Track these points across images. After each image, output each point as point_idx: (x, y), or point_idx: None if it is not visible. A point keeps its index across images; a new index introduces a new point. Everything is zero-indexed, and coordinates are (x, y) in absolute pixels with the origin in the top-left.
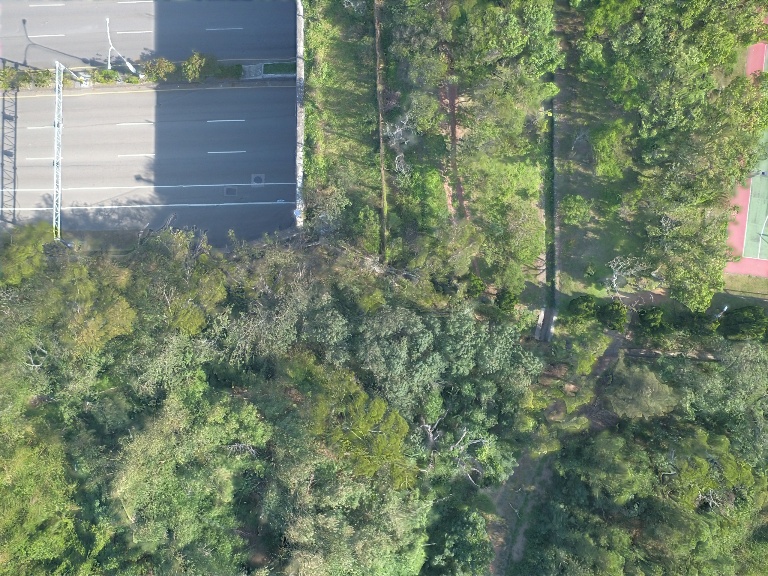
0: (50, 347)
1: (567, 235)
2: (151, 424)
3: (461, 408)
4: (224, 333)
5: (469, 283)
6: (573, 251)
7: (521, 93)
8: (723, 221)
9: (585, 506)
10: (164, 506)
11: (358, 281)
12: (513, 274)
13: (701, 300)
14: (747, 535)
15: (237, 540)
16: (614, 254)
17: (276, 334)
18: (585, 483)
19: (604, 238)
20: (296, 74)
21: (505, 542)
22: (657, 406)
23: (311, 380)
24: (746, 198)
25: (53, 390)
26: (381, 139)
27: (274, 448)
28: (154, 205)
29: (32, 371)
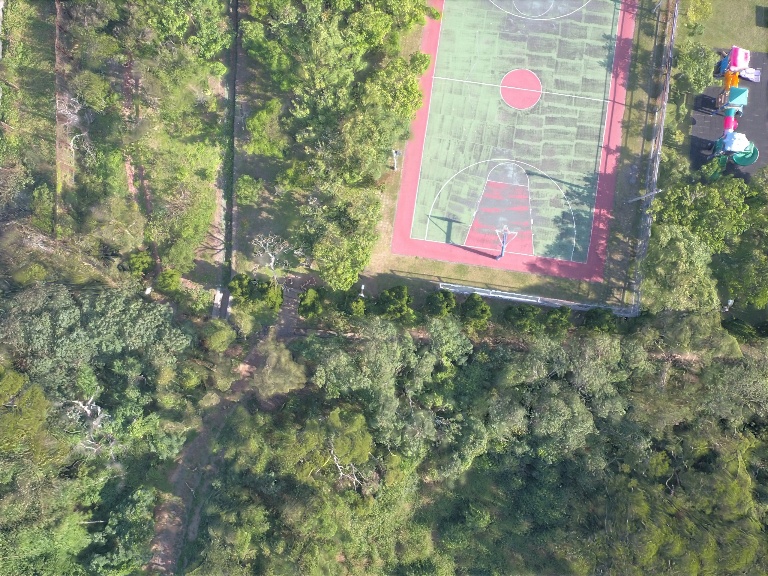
0: None
1: (243, 215)
2: None
3: (125, 385)
4: None
5: (129, 260)
6: (248, 231)
7: (174, 71)
8: (370, 200)
9: None
10: None
11: (49, 260)
12: (179, 252)
13: (339, 278)
14: (408, 516)
15: None
16: (287, 234)
17: None
18: None
19: (278, 218)
20: None
21: (181, 521)
22: (281, 383)
23: None
24: (415, 179)
25: None
26: (56, 117)
27: None
28: None
29: None
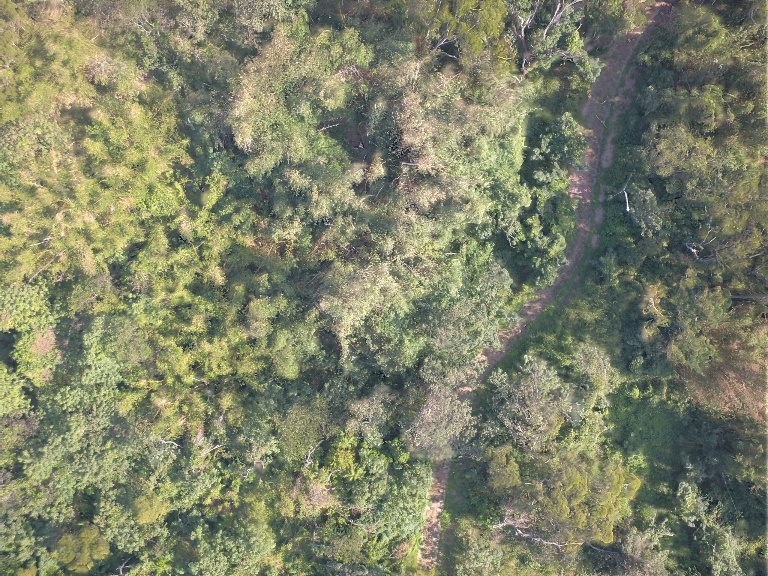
0: (157, 17)
1: None
2: (258, 68)
3: None
4: None
5: None
6: None
7: None
8: None
9: None
10: (277, 133)
11: None
12: None
13: None
14: None
15: (346, 162)
16: None
17: None
18: (669, 67)
19: None
20: None
21: (594, 152)
22: None
23: (407, 3)
24: None
25: (160, 64)
26: None
27: (376, 68)
28: None
29: (143, 36)
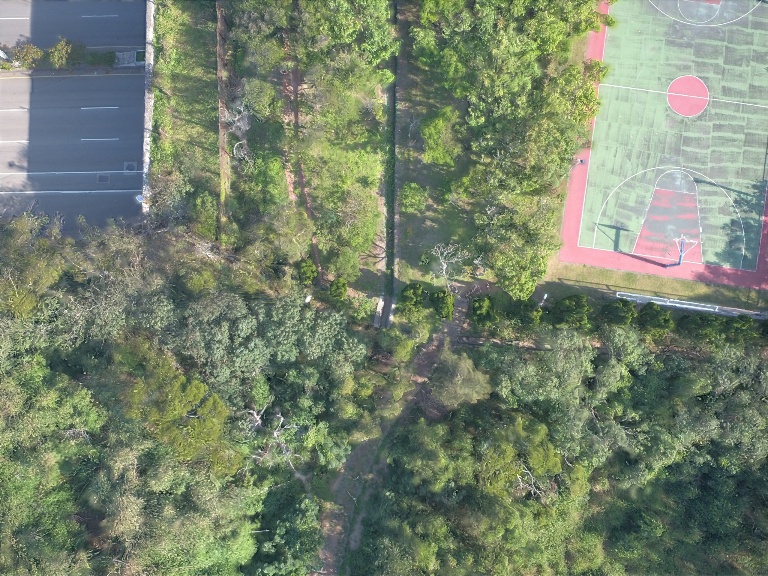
0: None
1: (406, 223)
2: None
3: (293, 395)
4: (54, 317)
5: (299, 269)
6: (411, 239)
7: (349, 79)
8: (548, 209)
9: (411, 494)
10: (0, 490)
11: (204, 268)
12: (346, 261)
13: (521, 288)
14: (578, 524)
15: (73, 525)
16: None
17: (105, 319)
18: (412, 471)
19: (442, 226)
20: (145, 60)
21: (343, 530)
22: (470, 393)
23: (145, 365)
24: (582, 187)
25: None
26: (219, 125)
27: (108, 433)
28: (27, 192)
29: None
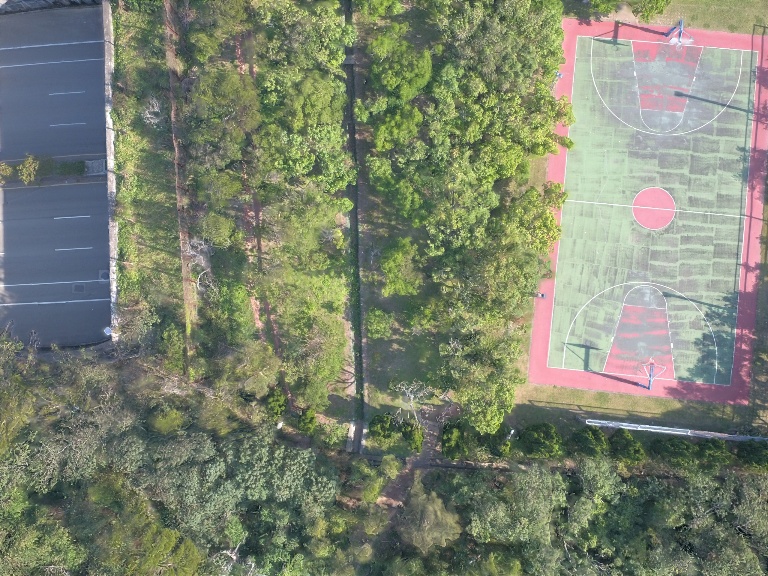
0: None
1: (373, 347)
2: None
3: (267, 528)
4: (26, 462)
5: (267, 405)
6: (379, 364)
7: (306, 216)
8: (512, 340)
9: None
10: None
11: (176, 394)
12: (314, 392)
13: (487, 424)
14: None
15: None
16: (420, 366)
17: (76, 462)
18: None
19: (410, 350)
20: None
21: None
22: (438, 536)
23: (120, 502)
24: (549, 307)
25: None
26: (181, 258)
27: (87, 570)
28: (4, 304)
29: None
